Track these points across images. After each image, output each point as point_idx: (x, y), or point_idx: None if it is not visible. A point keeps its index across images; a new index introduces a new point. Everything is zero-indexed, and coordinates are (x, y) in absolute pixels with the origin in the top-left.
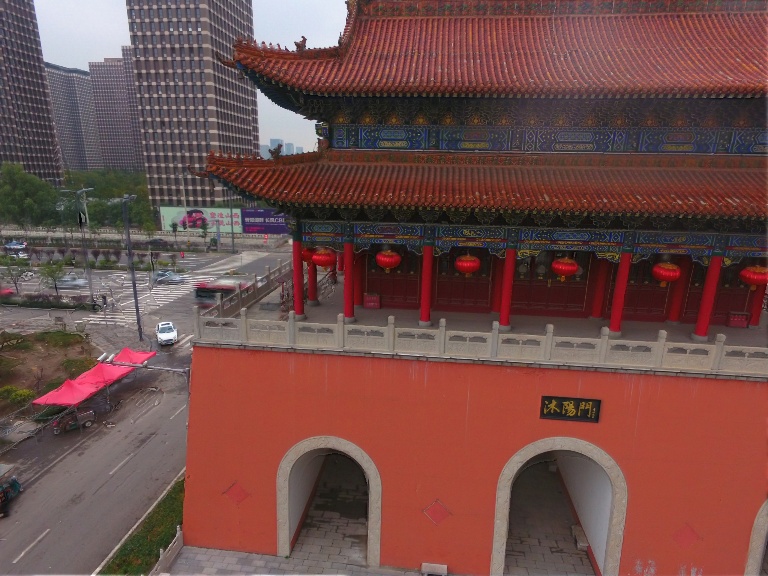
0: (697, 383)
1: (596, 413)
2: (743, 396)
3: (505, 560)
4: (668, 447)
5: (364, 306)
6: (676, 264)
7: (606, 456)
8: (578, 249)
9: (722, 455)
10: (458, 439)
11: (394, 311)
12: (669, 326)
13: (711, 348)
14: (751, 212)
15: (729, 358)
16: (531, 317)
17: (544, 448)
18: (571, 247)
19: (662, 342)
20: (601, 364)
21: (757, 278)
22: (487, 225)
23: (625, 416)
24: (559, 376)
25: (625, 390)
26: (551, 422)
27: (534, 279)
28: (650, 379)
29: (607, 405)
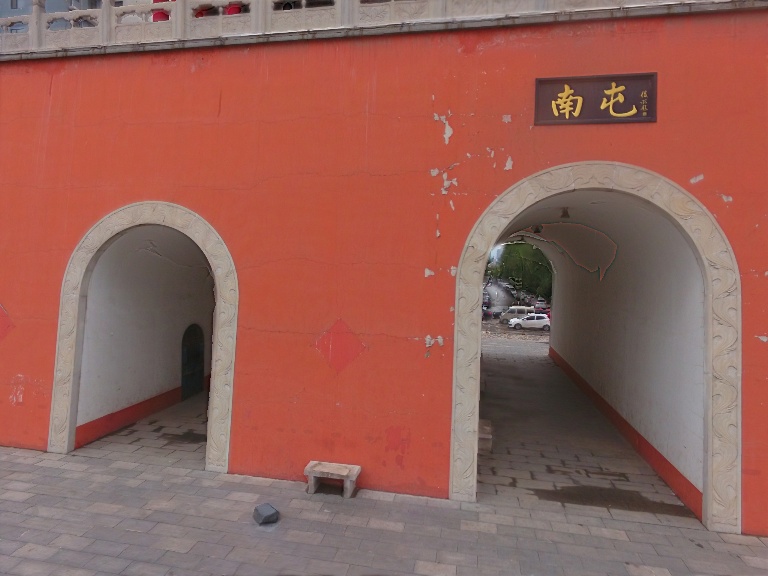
0: None
1: None
2: None
3: (547, 358)
4: None
5: None
6: None
7: None
8: None
9: None
10: (602, 241)
11: None
12: None
13: None
14: None
15: None
16: None
17: None
18: None
19: None
20: None
21: None
22: None
23: None
24: None
25: None
26: None
27: None
28: None
29: None
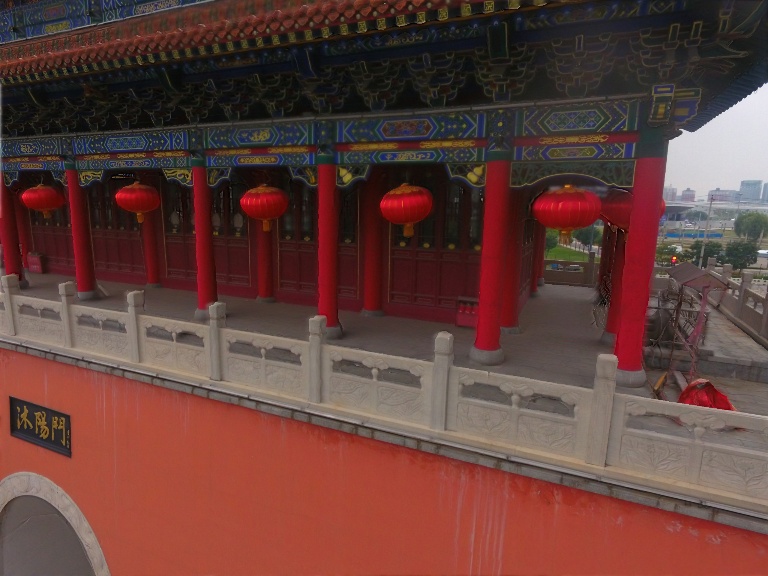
0: (188, 404)
1: (69, 439)
2: (261, 445)
3: None
4: (161, 529)
5: (29, 269)
6: (281, 188)
7: (86, 523)
8: (139, 165)
9: (242, 571)
10: None
11: (55, 277)
12: (352, 316)
13: (204, 332)
14: (233, 29)
15: (236, 357)
16: (187, 292)
17: (20, 488)
18: (131, 162)
19: (131, 313)
20: (62, 348)
21: (385, 205)
22: (39, 135)
23: (102, 452)
24: (20, 364)
25: (96, 402)
26: (22, 444)
27: (188, 234)
28: (124, 386)
29: (79, 427)
